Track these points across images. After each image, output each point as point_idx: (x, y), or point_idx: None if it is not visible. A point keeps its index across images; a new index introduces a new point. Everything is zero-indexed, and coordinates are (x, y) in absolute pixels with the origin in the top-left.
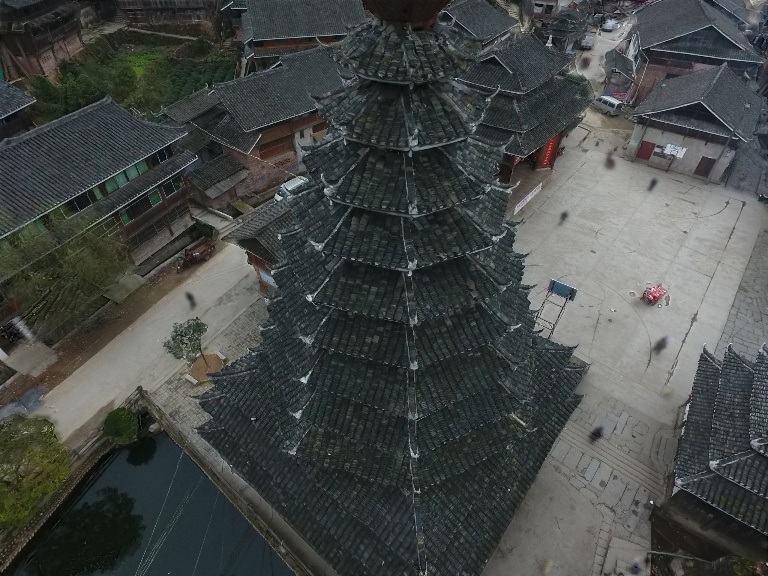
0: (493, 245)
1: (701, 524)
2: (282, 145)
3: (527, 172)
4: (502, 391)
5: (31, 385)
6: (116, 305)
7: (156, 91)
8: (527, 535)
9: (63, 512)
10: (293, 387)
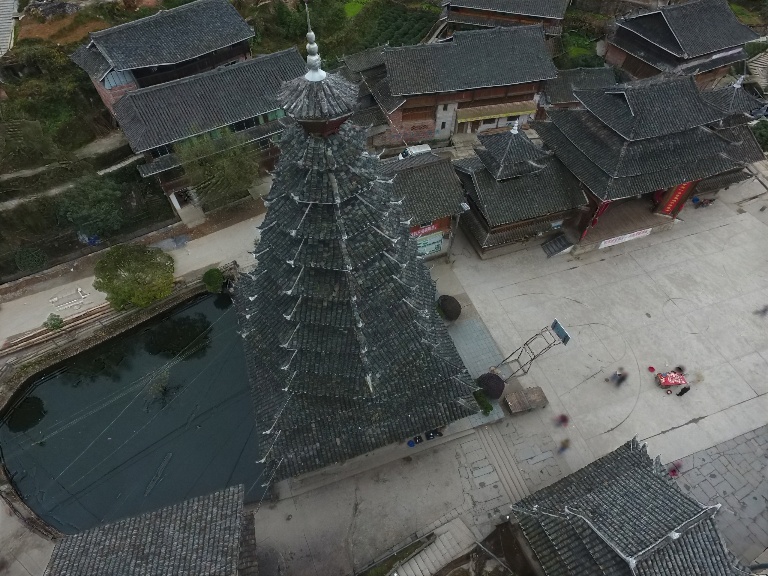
0: (375, 270)
1: (533, 554)
2: (425, 112)
3: (643, 212)
4: (359, 362)
5: (185, 232)
6: (252, 200)
7: (360, 32)
8: (402, 480)
9: (170, 314)
10: None
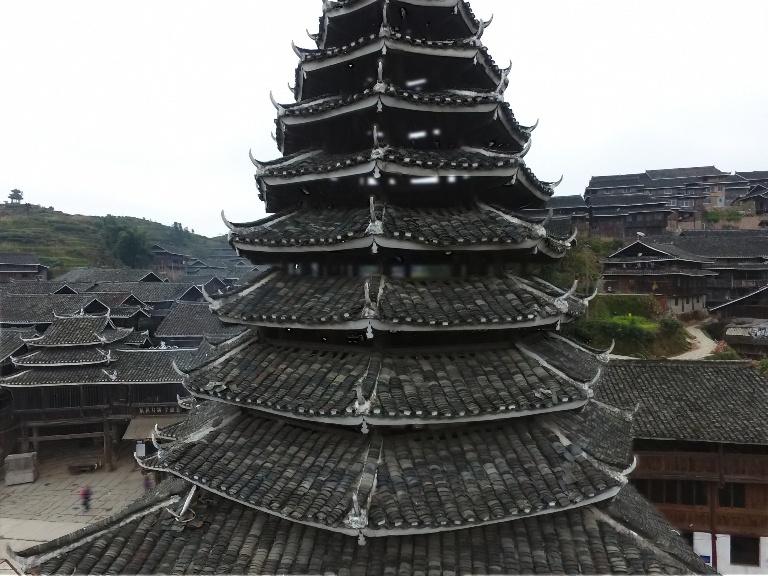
0: None
1: None
2: None
3: None
4: None
5: None
6: None
7: None
8: None
9: None
10: (590, 364)
